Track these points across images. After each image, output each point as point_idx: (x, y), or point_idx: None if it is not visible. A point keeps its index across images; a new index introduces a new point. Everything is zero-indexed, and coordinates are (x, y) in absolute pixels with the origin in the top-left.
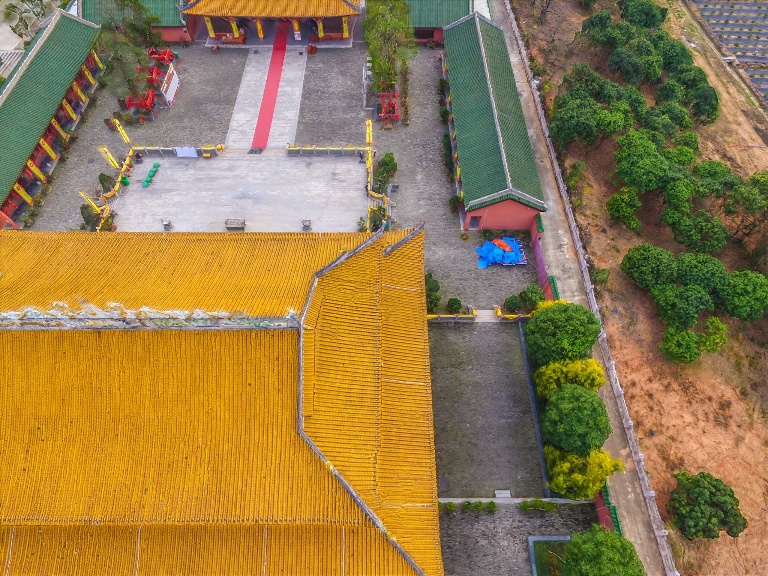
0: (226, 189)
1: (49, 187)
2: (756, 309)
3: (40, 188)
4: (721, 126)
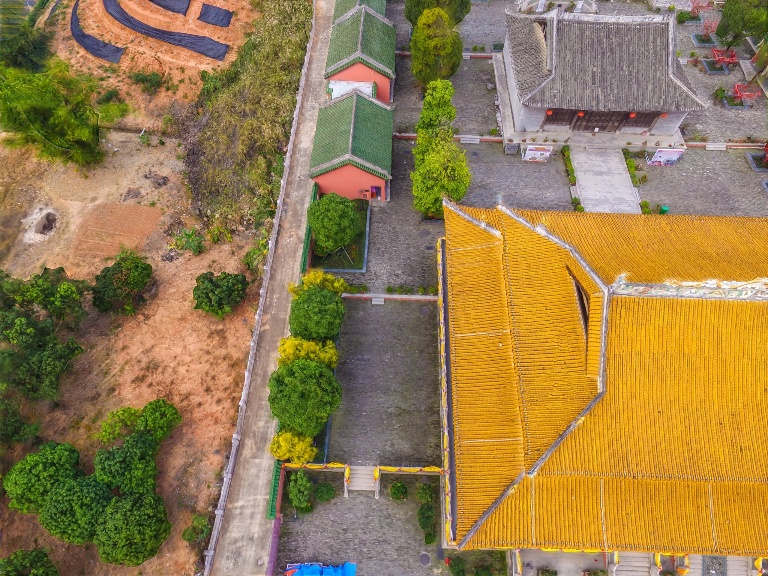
0: None
1: None
2: None
3: None
4: None
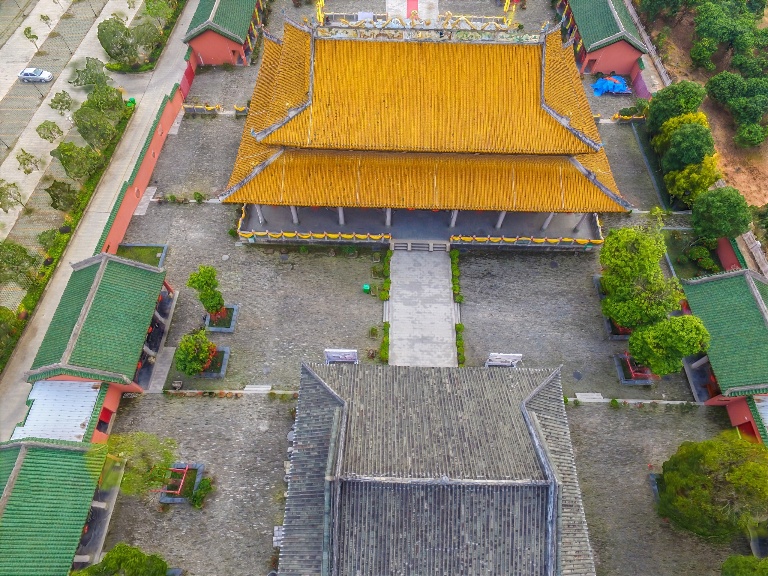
0: None
1: (261, 40)
2: None
3: (254, 41)
4: None
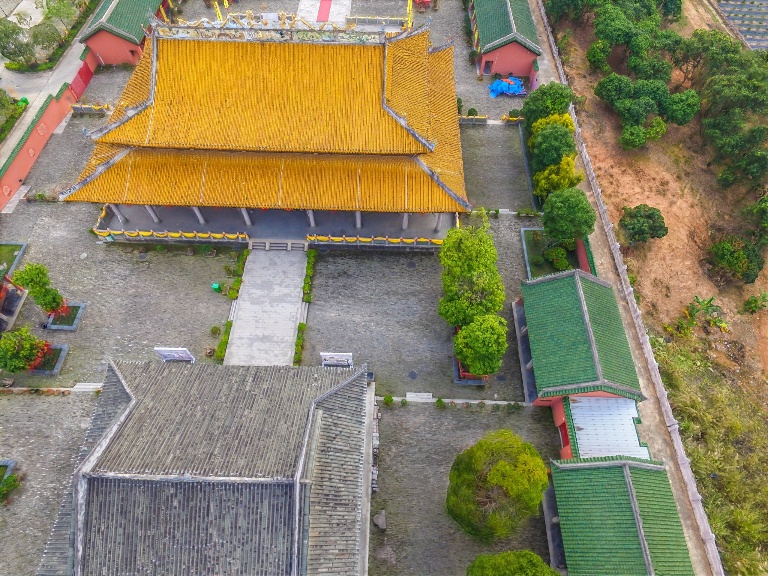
0: None
1: None
2: (688, 113)
3: None
4: (688, 32)
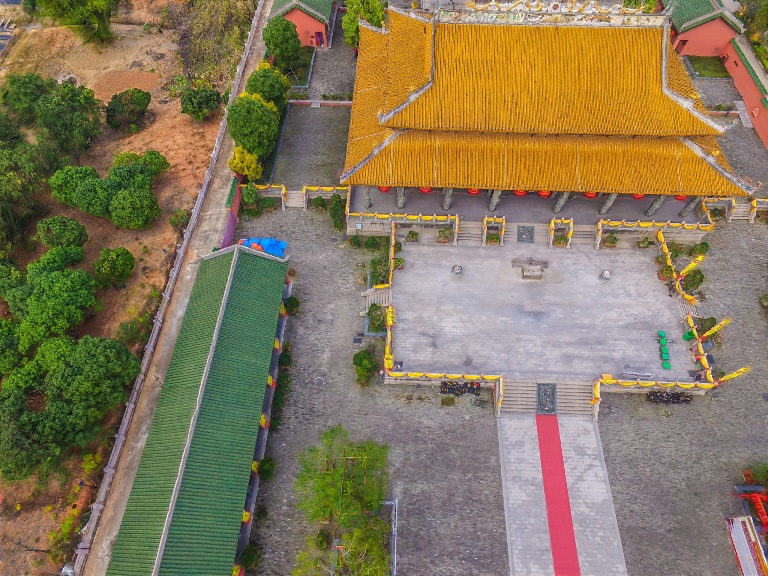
0: (561, 326)
1: None
2: None
3: None
4: None
